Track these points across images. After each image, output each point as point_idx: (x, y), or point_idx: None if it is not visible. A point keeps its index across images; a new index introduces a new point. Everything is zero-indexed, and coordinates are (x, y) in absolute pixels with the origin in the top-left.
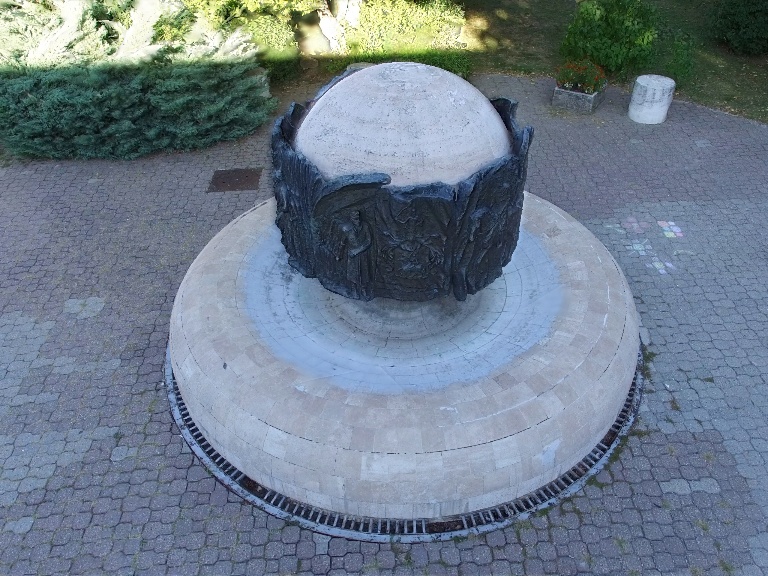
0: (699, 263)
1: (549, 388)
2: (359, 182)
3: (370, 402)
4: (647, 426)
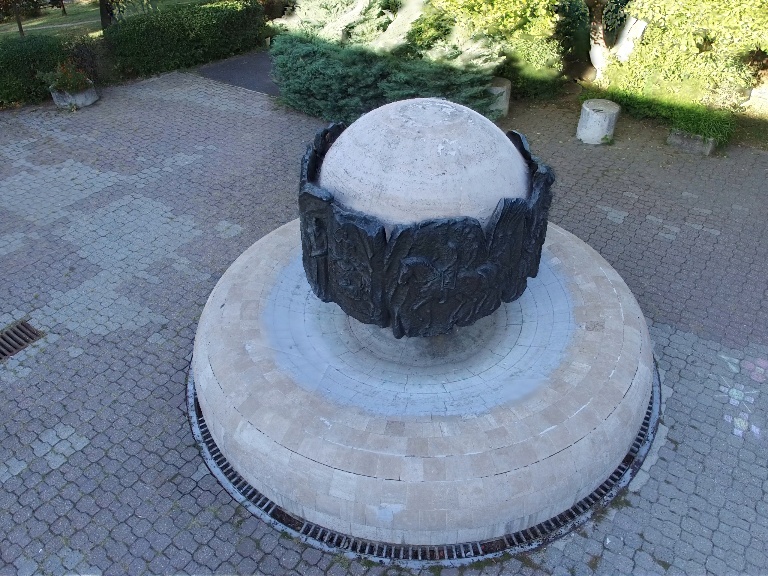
0: None
1: (423, 455)
2: (309, 192)
3: (280, 384)
4: (543, 561)
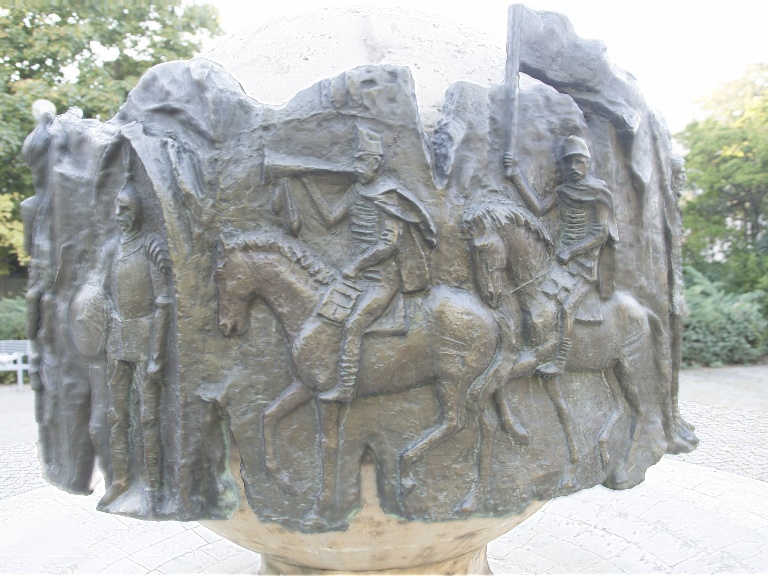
0: None
1: None
2: None
3: None
4: None
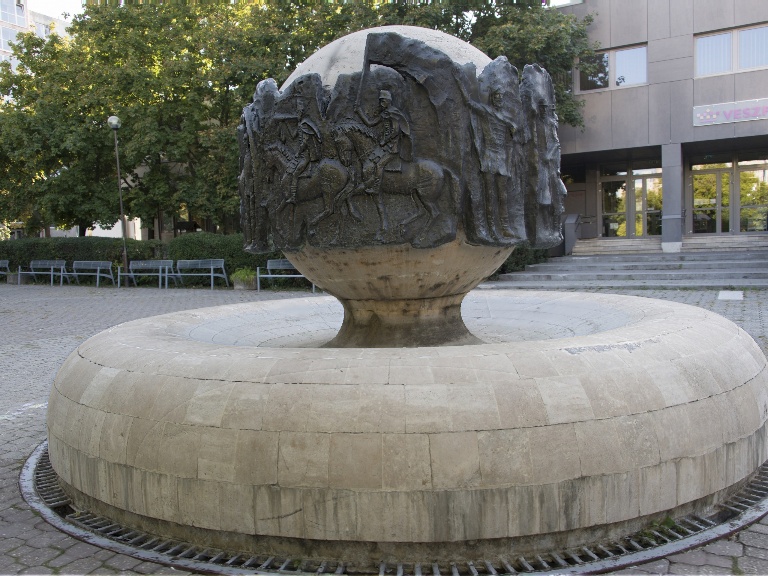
0: (2, 401)
1: None
2: None
3: (520, 292)
4: None
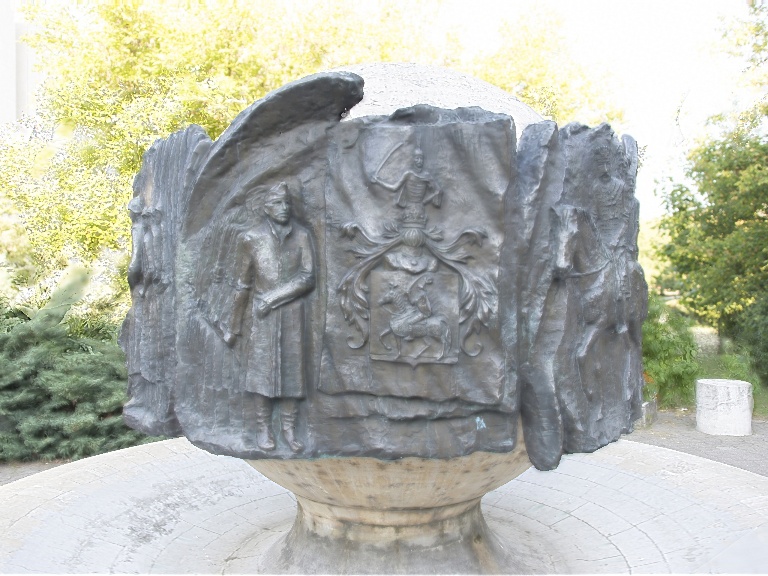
0: None
1: None
2: (288, 85)
3: None
4: None
